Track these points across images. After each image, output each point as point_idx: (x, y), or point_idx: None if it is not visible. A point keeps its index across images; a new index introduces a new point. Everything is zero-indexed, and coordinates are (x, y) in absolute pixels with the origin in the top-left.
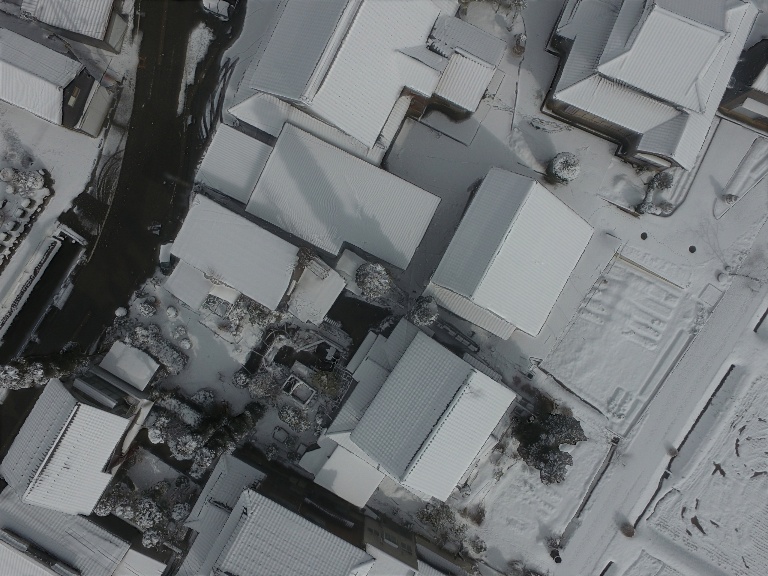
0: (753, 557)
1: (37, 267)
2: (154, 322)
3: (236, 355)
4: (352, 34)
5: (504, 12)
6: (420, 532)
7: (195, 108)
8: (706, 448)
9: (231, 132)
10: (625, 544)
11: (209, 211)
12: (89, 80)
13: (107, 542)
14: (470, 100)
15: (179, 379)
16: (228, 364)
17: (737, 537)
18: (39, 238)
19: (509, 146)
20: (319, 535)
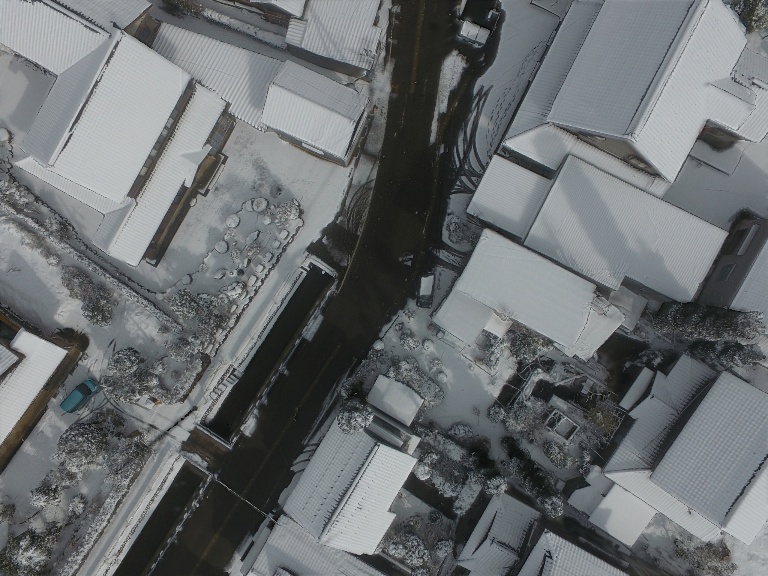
0: None
1: (284, 298)
2: (411, 355)
3: (491, 388)
4: (678, 68)
5: None
6: (665, 568)
7: (448, 137)
8: None
9: (506, 164)
10: None
11: (499, 246)
12: None
13: None
14: (757, 131)
15: (432, 412)
16: (483, 398)
17: None
18: (288, 269)
19: None
20: None
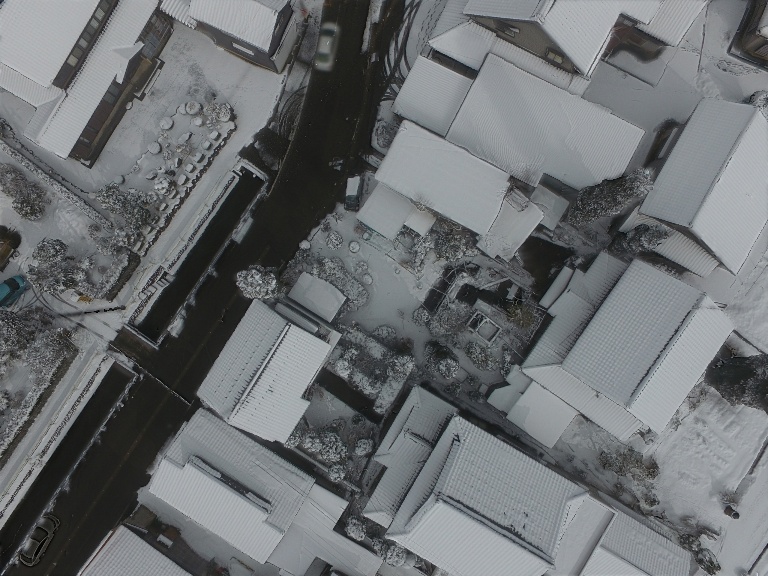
0: None
1: (215, 201)
2: (337, 256)
3: (416, 292)
4: None
5: None
6: (592, 482)
7: (379, 46)
8: None
9: (429, 64)
10: None
11: (416, 137)
12: (290, 11)
13: (294, 475)
14: (674, 34)
15: (358, 315)
16: (408, 301)
17: None
18: (219, 172)
19: (696, 87)
20: (531, 465)
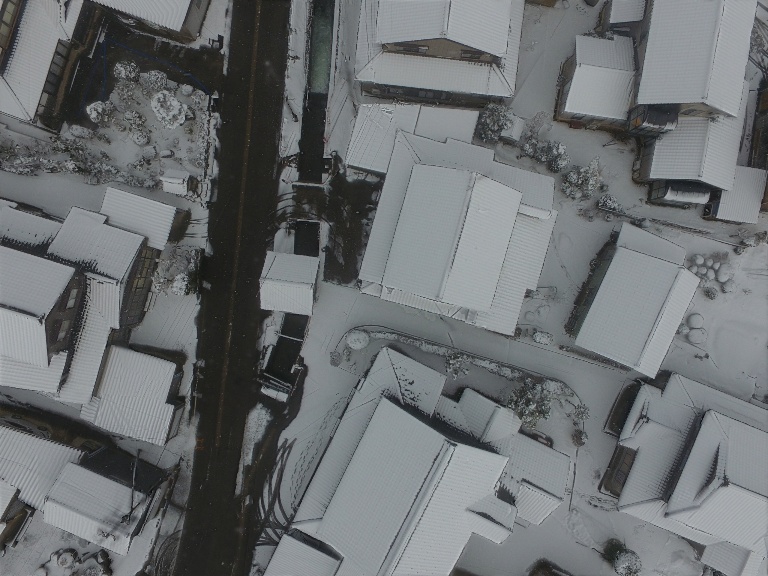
0: None
1: None
2: None
3: None
4: (426, 516)
5: (563, 398)
6: None
7: (253, 488)
8: None
9: (294, 544)
10: None
11: None
12: (151, 495)
13: None
14: (534, 518)
15: None
16: None
17: None
18: None
19: (567, 527)
20: None
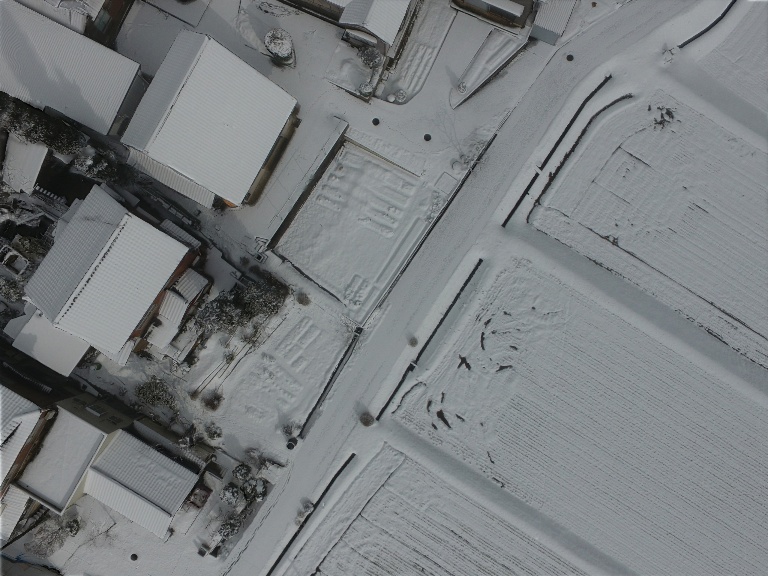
0: (498, 452)
1: None
2: None
3: None
4: None
5: None
6: None
7: None
8: (450, 340)
9: None
10: (365, 435)
11: None
12: None
13: None
14: None
15: None
16: None
17: (482, 431)
18: None
19: (235, 28)
20: None
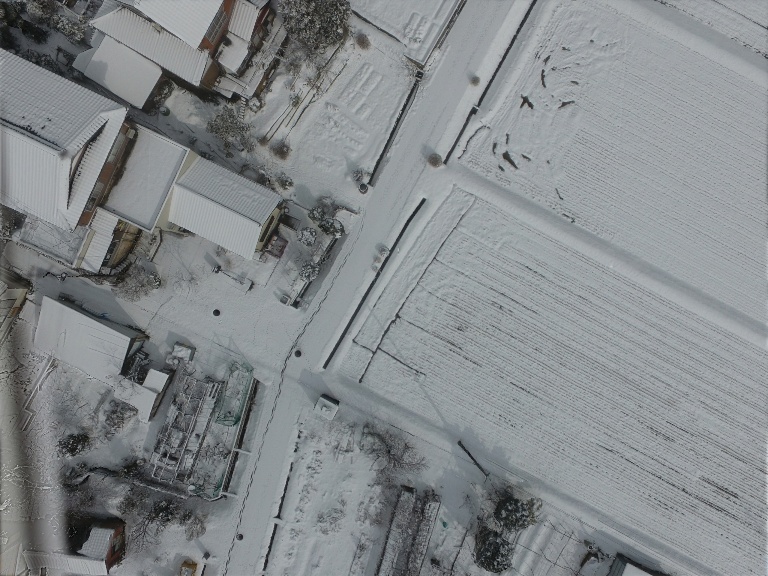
0: (566, 188)
1: None
2: None
3: None
4: None
5: None
6: None
7: None
8: (511, 79)
9: None
10: (435, 177)
11: None
12: None
13: None
14: None
15: None
16: None
17: (549, 169)
18: None
19: None
20: (68, 86)
